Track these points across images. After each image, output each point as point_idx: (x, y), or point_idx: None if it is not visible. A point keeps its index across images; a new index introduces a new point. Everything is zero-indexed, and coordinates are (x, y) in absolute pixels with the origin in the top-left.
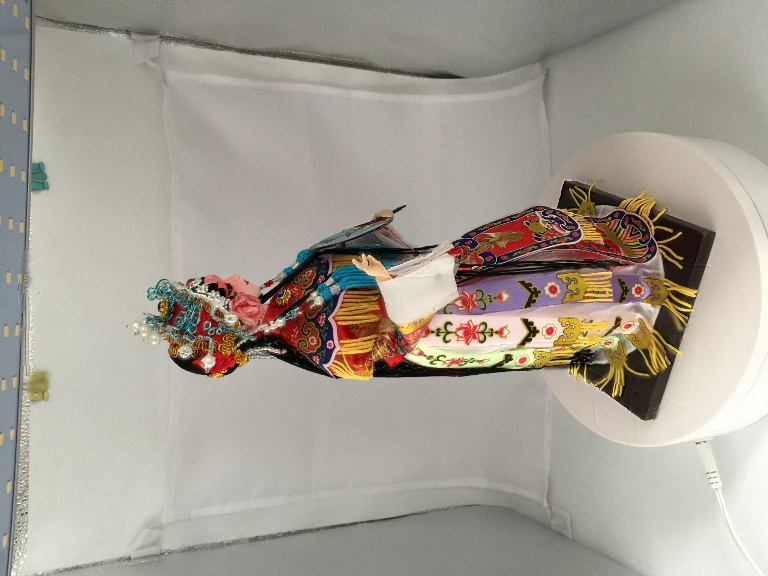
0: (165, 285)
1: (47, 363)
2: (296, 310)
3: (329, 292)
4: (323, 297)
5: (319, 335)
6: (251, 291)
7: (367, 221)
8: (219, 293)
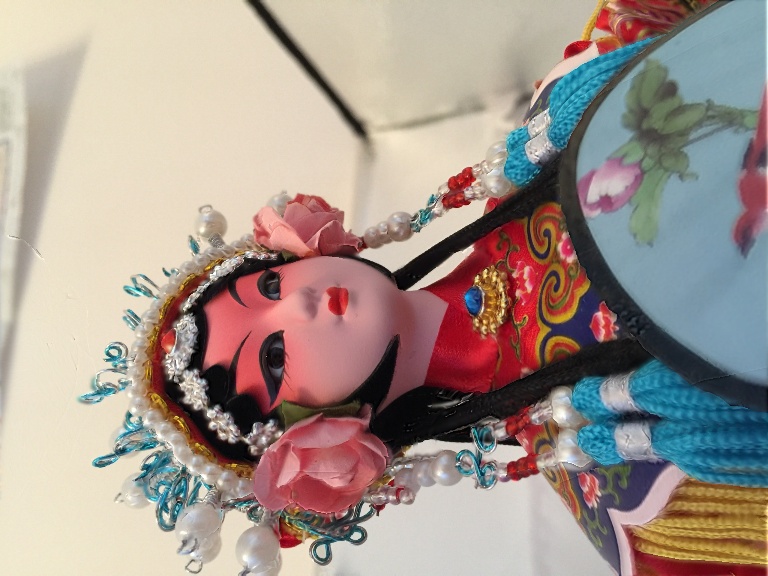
0: (120, 348)
1: (5, 496)
2: (499, 434)
3: (610, 456)
4: (587, 454)
5: (580, 520)
6: (348, 359)
7: None
8: (233, 421)
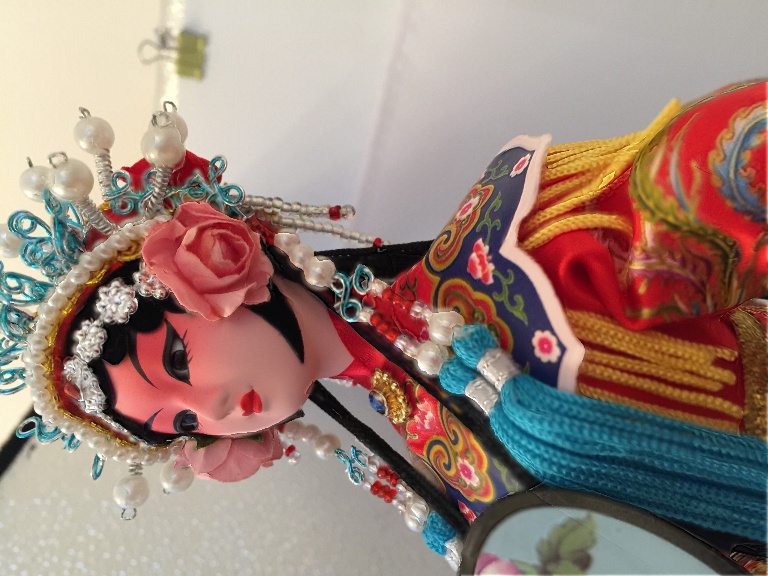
0: None
1: None
2: (371, 465)
3: None
4: None
5: None
6: (257, 430)
7: None
8: (151, 444)
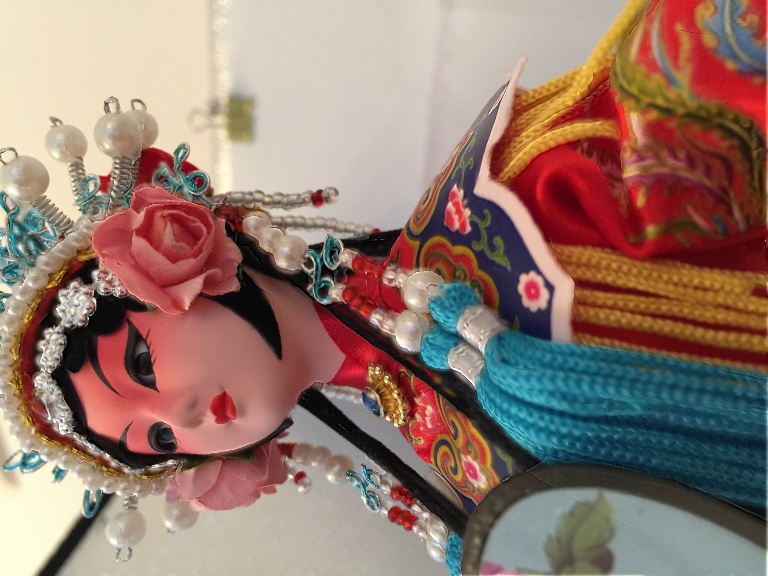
0: None
1: None
2: (384, 485)
3: None
4: None
5: None
6: (242, 444)
7: None
8: (135, 469)
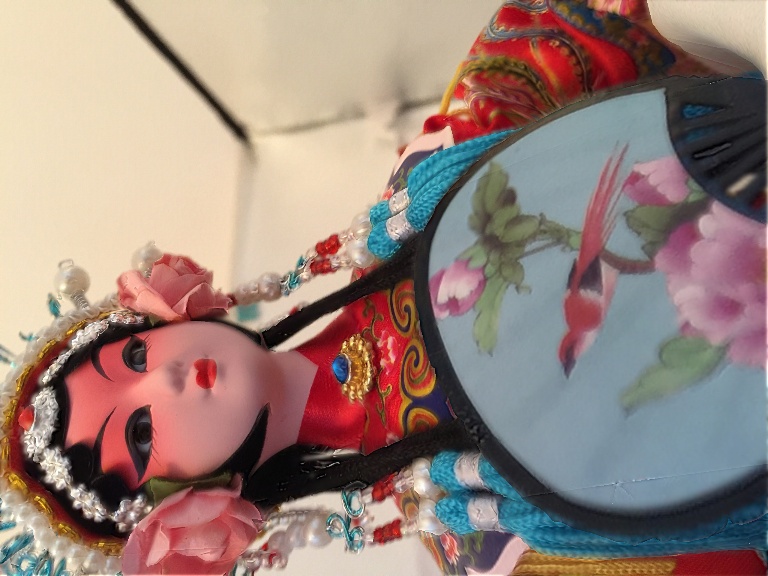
0: None
1: None
2: (366, 500)
3: (464, 528)
4: (444, 524)
5: (442, 573)
6: (217, 432)
7: (761, 29)
8: (98, 501)
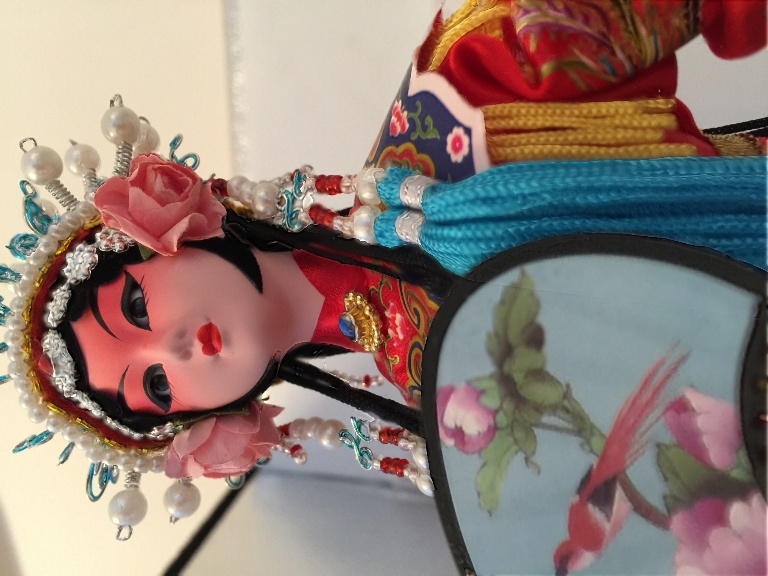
0: None
1: None
2: (374, 433)
3: None
4: None
5: None
6: (231, 386)
7: None
8: (134, 431)
